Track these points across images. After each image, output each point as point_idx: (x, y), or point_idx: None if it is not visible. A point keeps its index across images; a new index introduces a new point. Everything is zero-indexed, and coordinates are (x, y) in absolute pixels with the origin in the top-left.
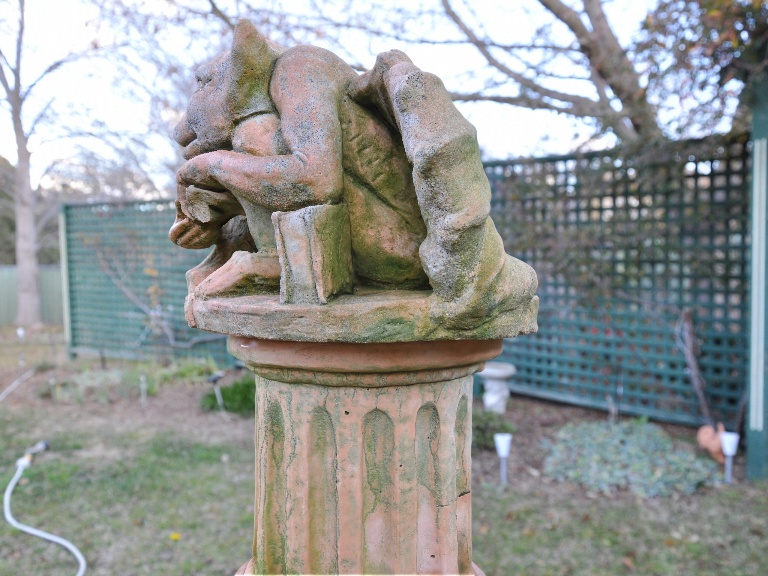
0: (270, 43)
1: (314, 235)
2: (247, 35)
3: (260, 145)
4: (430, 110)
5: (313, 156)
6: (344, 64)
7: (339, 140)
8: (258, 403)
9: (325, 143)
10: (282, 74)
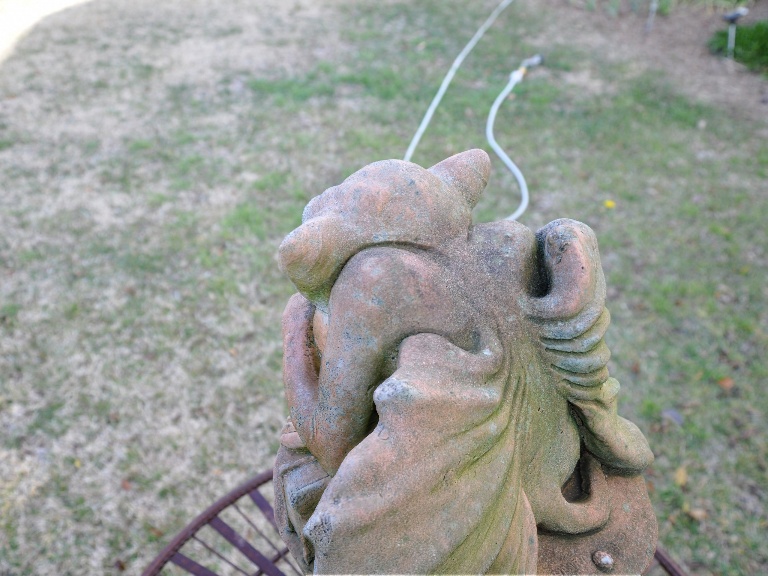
0: (373, 200)
1: (299, 516)
2: (288, 263)
3: (322, 347)
4: (330, 571)
5: (320, 435)
6: (409, 304)
7: (360, 417)
8: None
9: (337, 424)
10: (330, 304)
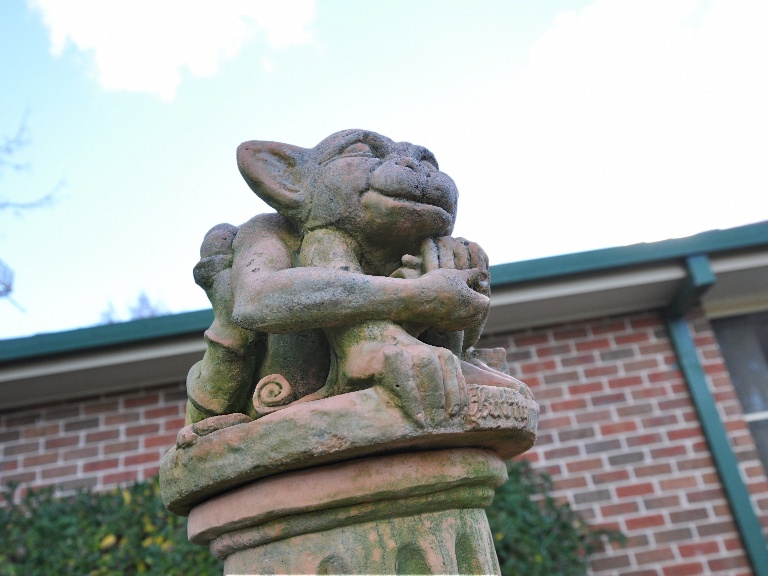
0: None
1: None
2: None
3: None
4: None
5: None
6: None
7: None
8: (483, 543)
9: None
10: None
